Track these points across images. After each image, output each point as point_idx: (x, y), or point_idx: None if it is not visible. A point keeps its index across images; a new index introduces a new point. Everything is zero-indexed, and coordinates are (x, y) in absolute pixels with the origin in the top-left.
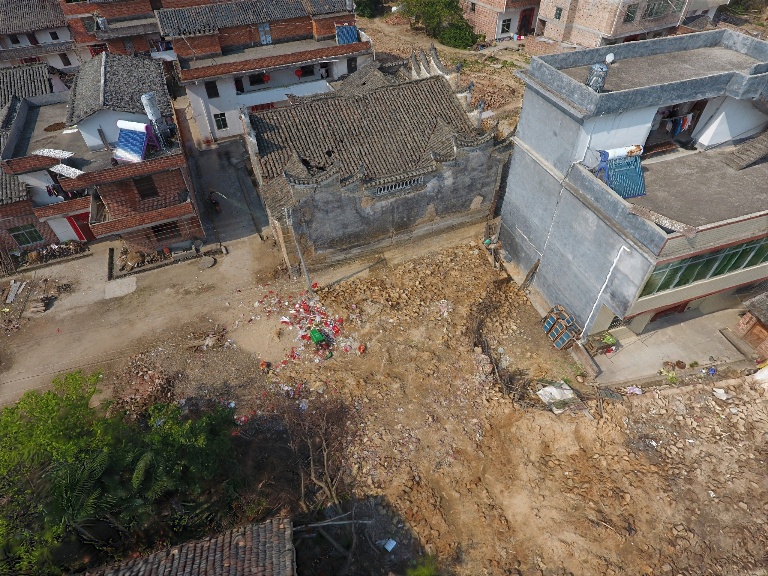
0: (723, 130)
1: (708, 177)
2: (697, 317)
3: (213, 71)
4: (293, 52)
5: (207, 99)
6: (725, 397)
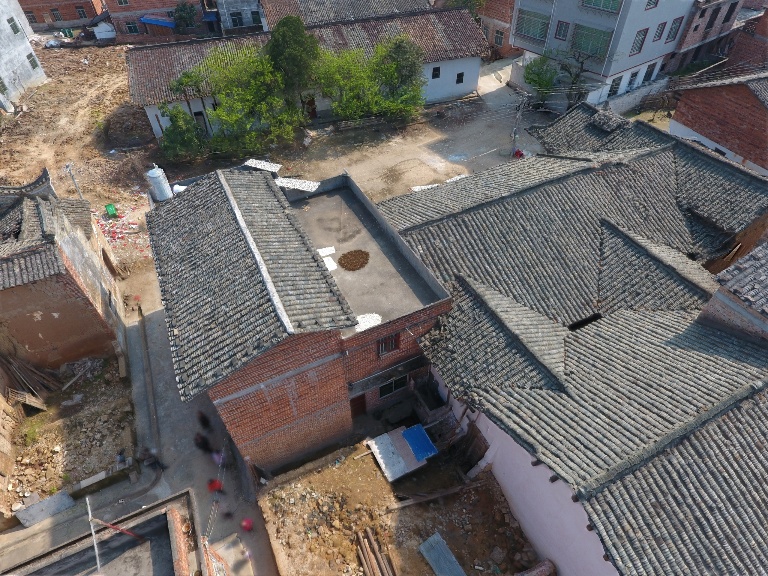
0: None
1: None
2: None
3: None
4: None
5: None
6: None
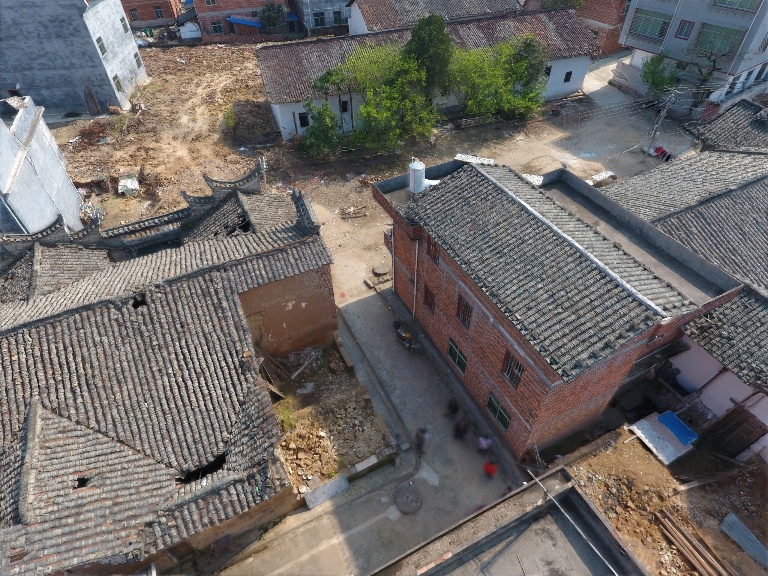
0: None
1: None
2: None
3: None
4: None
5: None
6: None
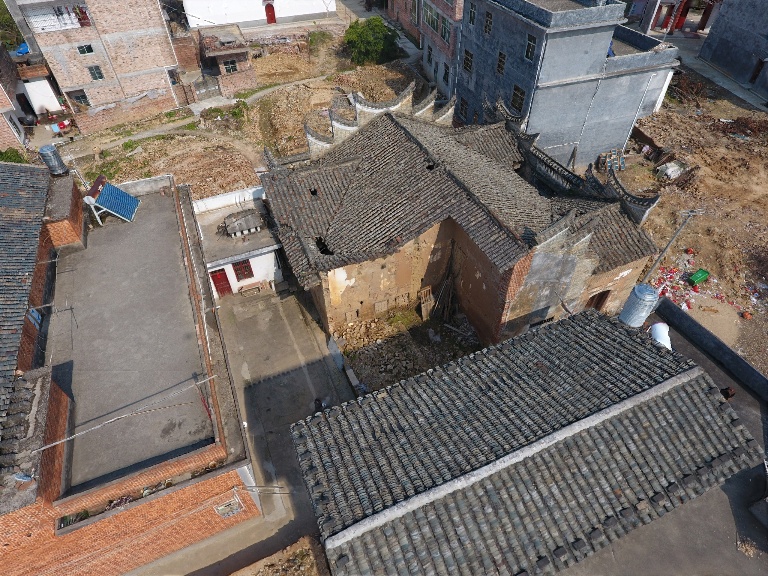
0: None
1: None
2: None
3: None
4: None
5: None
6: None
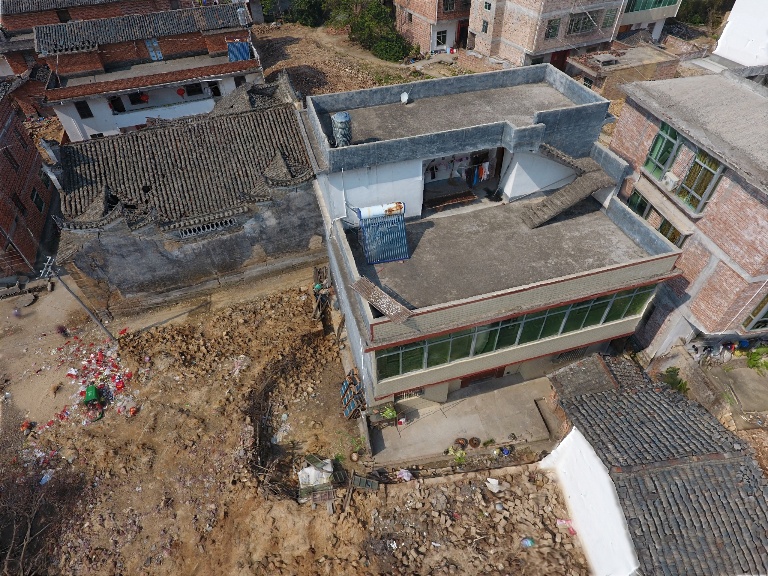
0: (524, 181)
1: (492, 237)
2: (515, 383)
3: (82, 91)
4: (175, 70)
5: (80, 119)
6: (497, 489)
